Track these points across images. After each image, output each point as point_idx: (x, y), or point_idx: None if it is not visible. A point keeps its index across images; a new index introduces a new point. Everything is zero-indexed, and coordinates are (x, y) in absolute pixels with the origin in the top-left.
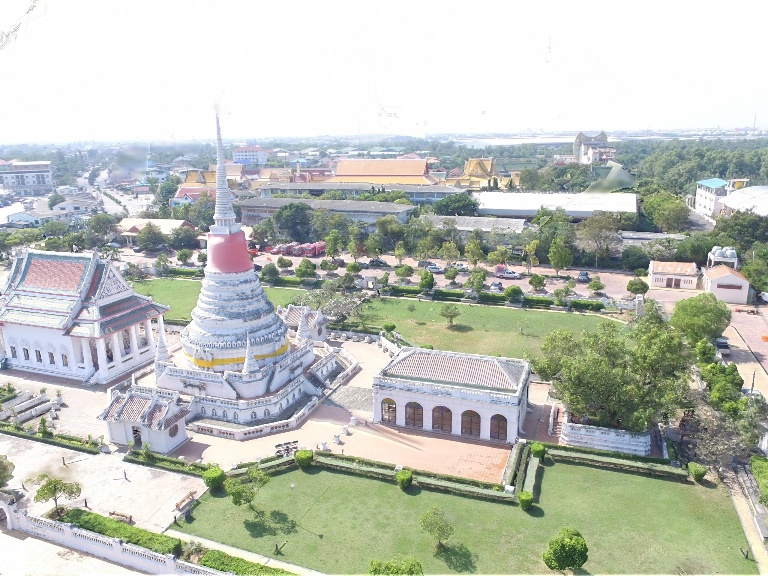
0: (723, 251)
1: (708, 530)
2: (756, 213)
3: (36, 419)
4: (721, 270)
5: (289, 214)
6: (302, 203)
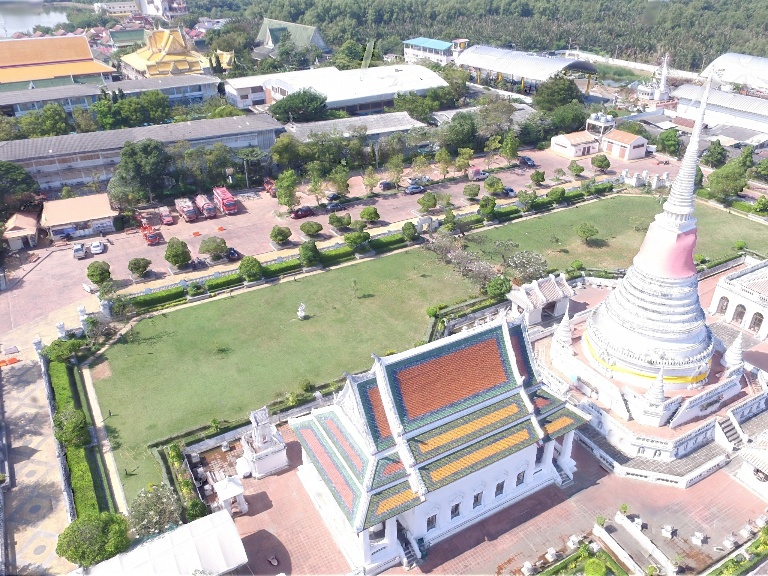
0: (606, 117)
1: None
2: (566, 78)
3: (666, 550)
4: (622, 134)
5: (155, 161)
6: (151, 140)
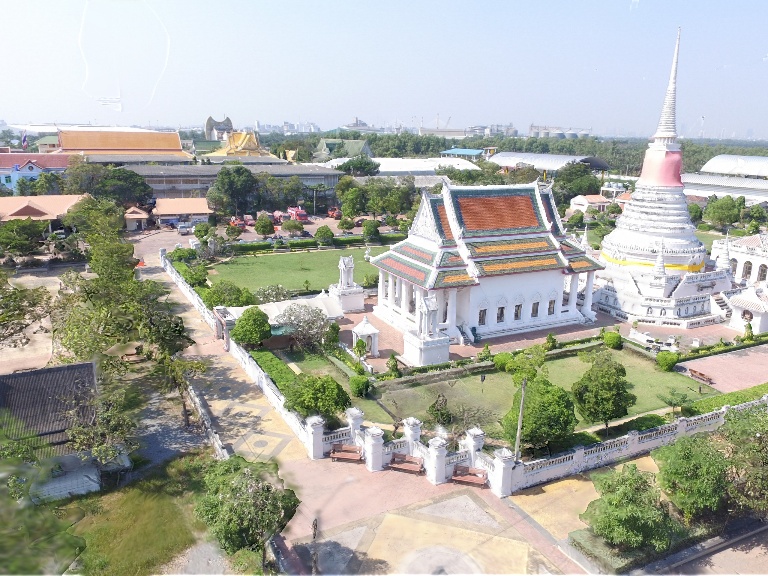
0: None
1: None
2: (582, 163)
3: None
4: None
5: (245, 179)
6: None
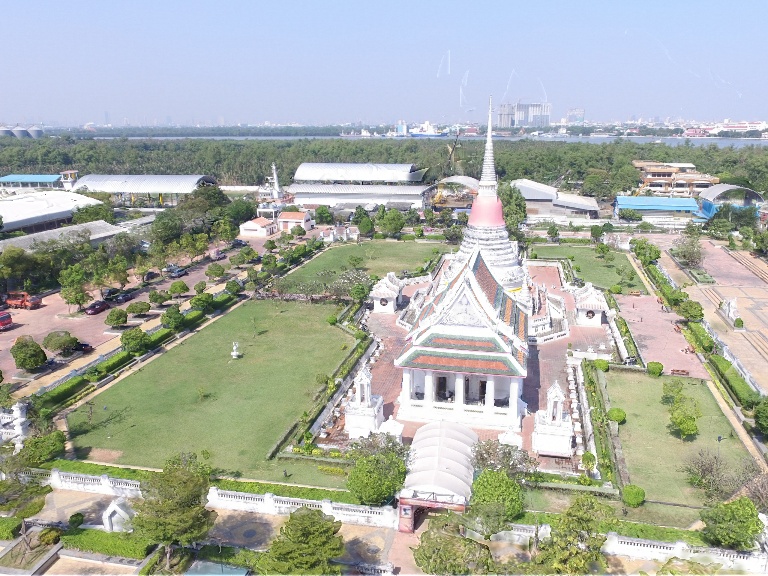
0: None
1: (560, 248)
2: (213, 185)
3: None
4: (292, 214)
5: None
6: None
